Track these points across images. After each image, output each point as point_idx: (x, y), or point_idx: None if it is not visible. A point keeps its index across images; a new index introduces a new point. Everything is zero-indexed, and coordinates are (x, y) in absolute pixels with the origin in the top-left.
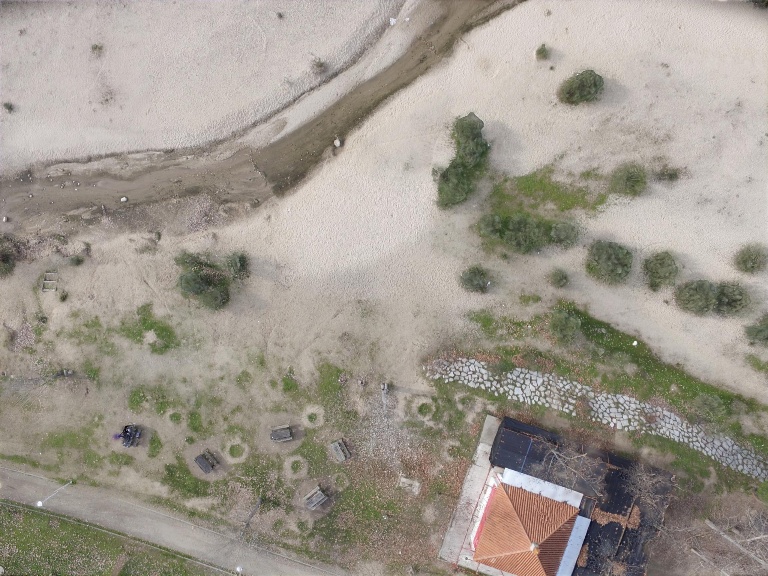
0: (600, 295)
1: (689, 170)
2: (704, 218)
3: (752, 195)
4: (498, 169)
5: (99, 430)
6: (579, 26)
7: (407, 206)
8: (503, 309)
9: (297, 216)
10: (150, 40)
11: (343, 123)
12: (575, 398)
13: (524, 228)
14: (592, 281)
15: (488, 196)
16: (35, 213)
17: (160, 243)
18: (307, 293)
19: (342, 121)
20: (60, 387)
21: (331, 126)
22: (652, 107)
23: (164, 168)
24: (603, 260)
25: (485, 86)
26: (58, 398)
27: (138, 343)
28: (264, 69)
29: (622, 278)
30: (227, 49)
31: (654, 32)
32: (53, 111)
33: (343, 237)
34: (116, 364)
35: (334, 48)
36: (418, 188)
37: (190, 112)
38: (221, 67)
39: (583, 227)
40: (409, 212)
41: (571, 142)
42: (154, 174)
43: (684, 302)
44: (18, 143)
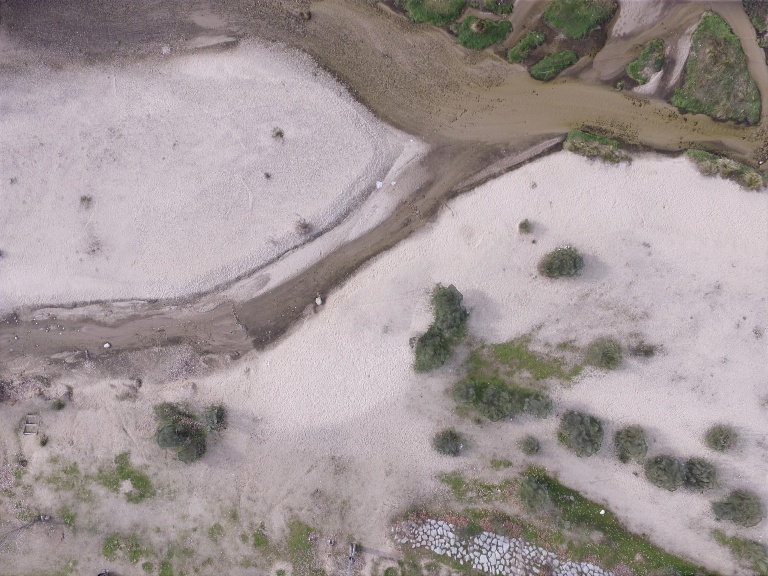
0: (570, 463)
1: (665, 348)
2: (678, 395)
3: (727, 375)
4: (476, 336)
5: (73, 575)
6: (563, 200)
7: (384, 368)
8: (474, 472)
9: (276, 371)
10: (138, 194)
11: (325, 281)
12: (539, 567)
13: (497, 402)
14: (563, 450)
15: (465, 361)
16: (20, 355)
17: (141, 390)
18: (282, 447)
19: (324, 279)
20: (37, 531)
21: (313, 284)
22: (632, 285)
23: (147, 317)
24: (574, 436)
25: (467, 255)
26: (35, 542)
27: (114, 492)
28: (249, 227)
29: (592, 453)
30: (214, 206)
31: (638, 211)
32: (41, 258)
33: (320, 395)
34: (92, 511)
35: (319, 210)
36: (396, 351)
37: (175, 266)
38: (207, 223)
39: (557, 397)
40: (386, 374)
41: (549, 314)
42: (137, 322)
43: (652, 479)
44: (5, 287)
